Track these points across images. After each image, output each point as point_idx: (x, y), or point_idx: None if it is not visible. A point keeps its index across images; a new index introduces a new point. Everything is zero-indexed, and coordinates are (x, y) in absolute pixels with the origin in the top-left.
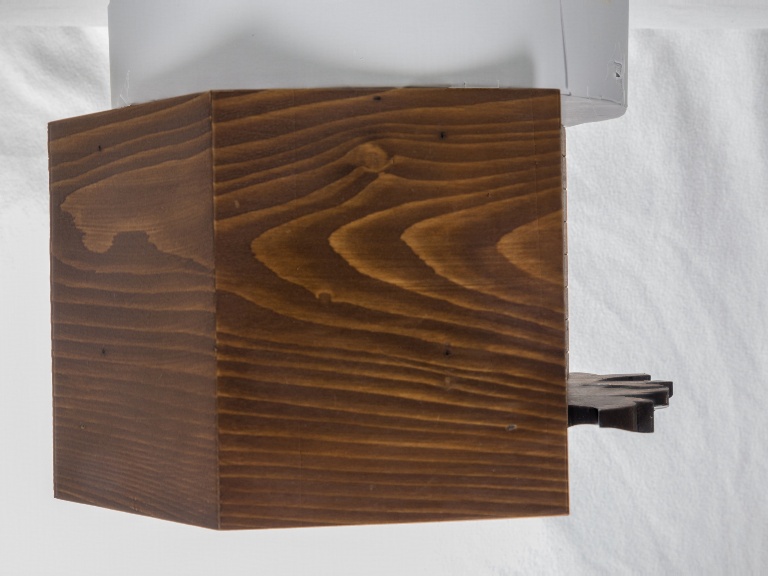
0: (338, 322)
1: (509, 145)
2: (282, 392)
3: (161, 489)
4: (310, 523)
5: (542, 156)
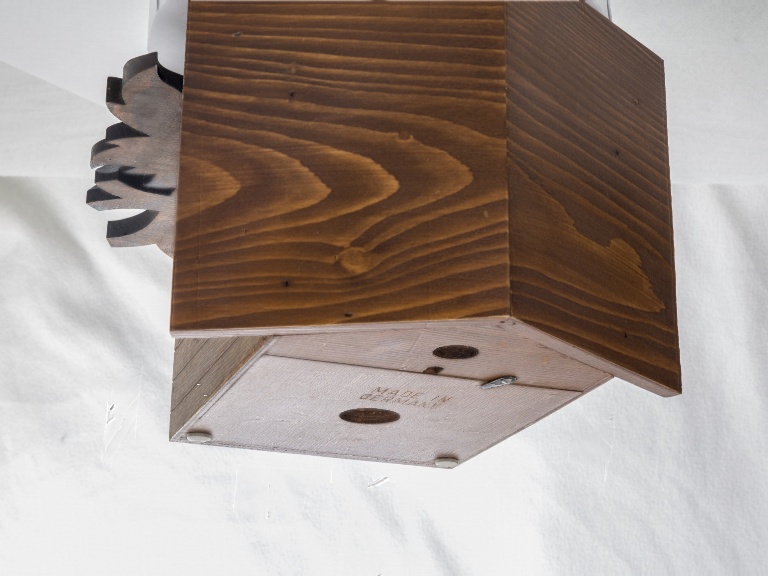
0: (393, 116)
1: (223, 277)
2: (446, 55)
3: (559, 6)
4: None
5: (192, 268)
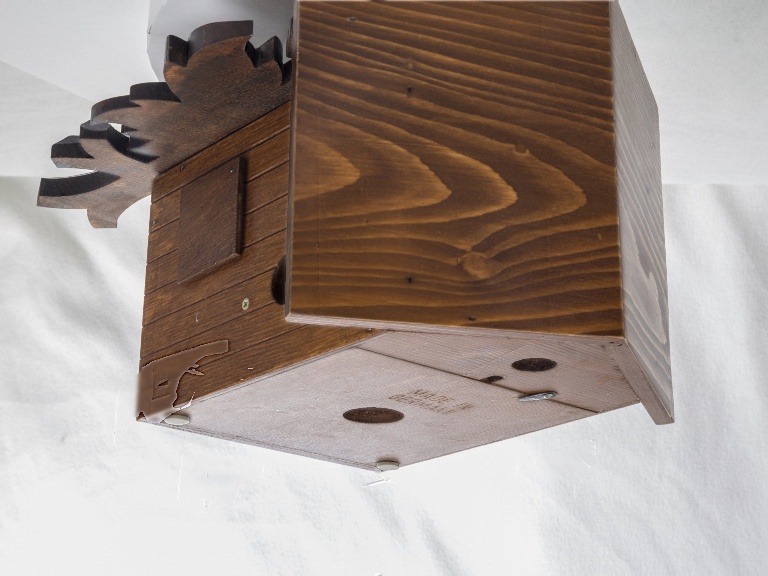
0: (509, 127)
1: (345, 265)
2: (558, 77)
3: None
4: None
5: (312, 252)
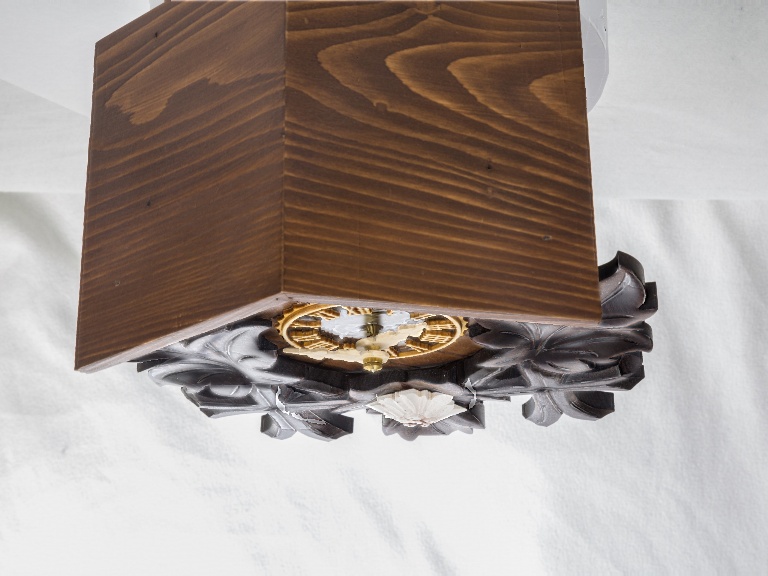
0: (393, 128)
1: (537, 11)
2: (343, 179)
3: (213, 290)
4: (367, 296)
5: (564, 23)
